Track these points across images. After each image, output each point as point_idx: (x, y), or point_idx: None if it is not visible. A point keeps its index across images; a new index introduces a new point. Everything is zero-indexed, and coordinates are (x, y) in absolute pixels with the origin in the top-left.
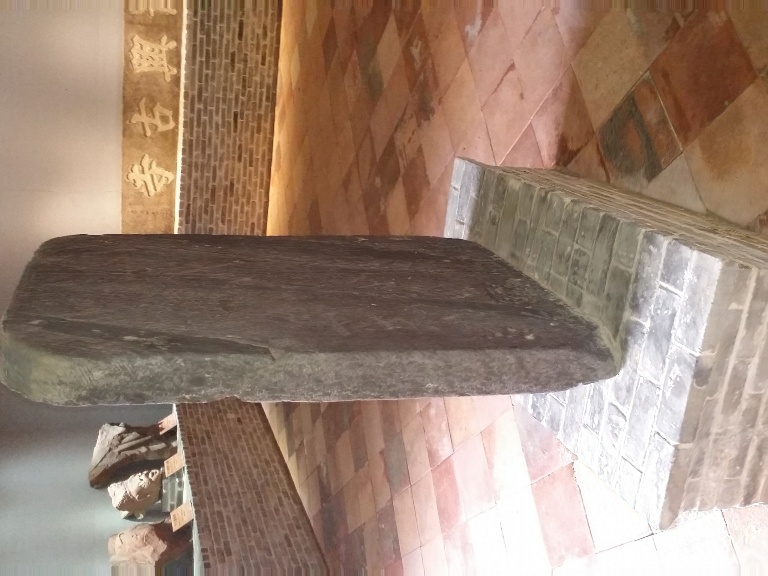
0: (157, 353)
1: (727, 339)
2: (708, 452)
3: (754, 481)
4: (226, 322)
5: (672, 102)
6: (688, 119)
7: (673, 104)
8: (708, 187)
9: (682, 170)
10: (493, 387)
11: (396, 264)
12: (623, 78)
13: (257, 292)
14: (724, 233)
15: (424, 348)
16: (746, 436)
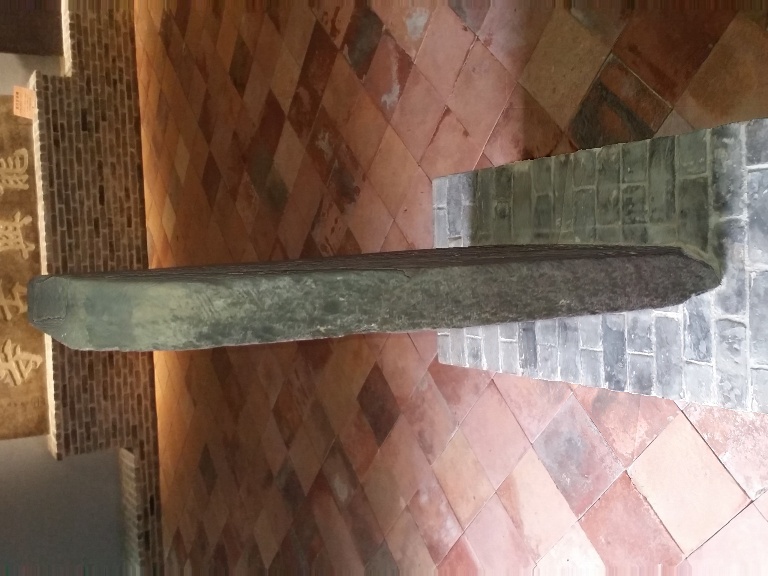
0: (282, 275)
1: None
2: None
3: None
4: None
5: (647, 69)
6: (670, 77)
7: (649, 71)
8: None
9: (677, 125)
10: (619, 302)
11: None
12: (584, 70)
13: (325, 261)
14: None
15: (550, 259)
16: None
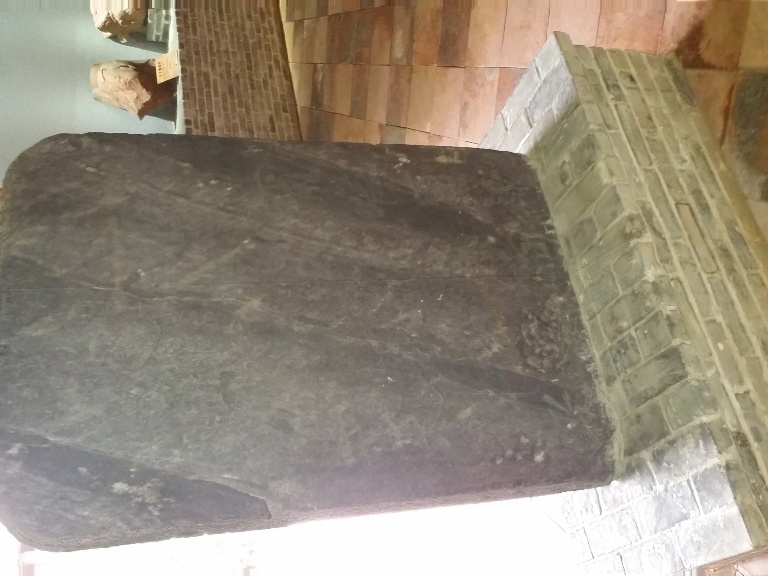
0: (148, 524)
1: None
2: None
3: None
4: (225, 437)
5: None
6: None
7: None
8: None
9: None
10: None
11: (432, 250)
12: None
13: (264, 346)
14: None
15: (426, 494)
16: None
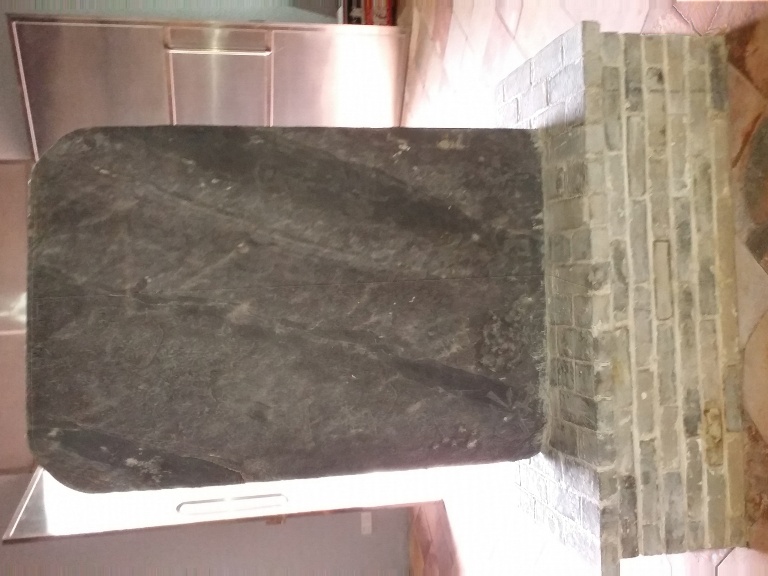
0: (152, 488)
1: None
2: None
3: None
4: (212, 425)
5: None
6: None
7: None
8: (760, 344)
9: (765, 296)
10: None
11: (413, 251)
12: None
13: (249, 348)
14: (704, 429)
15: (369, 472)
16: None
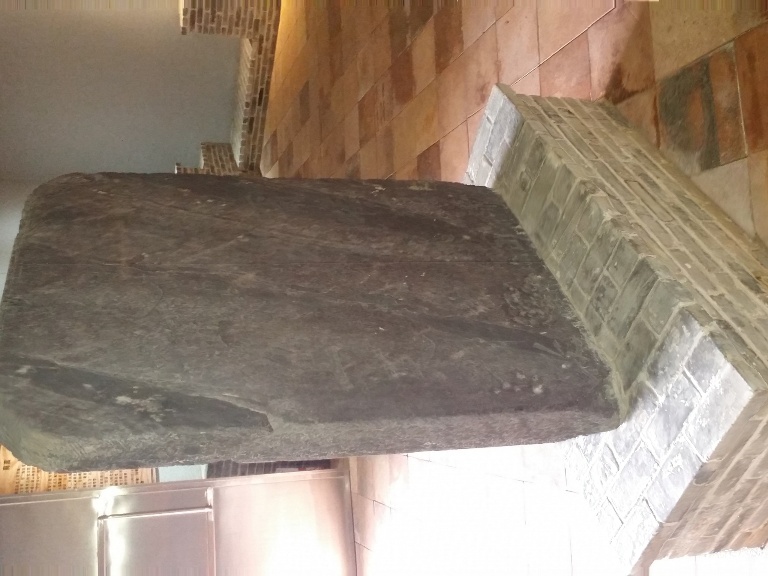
0: (151, 428)
1: (738, 444)
2: (691, 520)
3: (729, 537)
4: (224, 366)
5: (750, 94)
6: (763, 123)
7: (751, 97)
8: (764, 210)
9: (741, 177)
10: (492, 442)
11: (411, 244)
12: (702, 35)
13: (260, 304)
14: (767, 289)
15: (427, 414)
16: (732, 508)
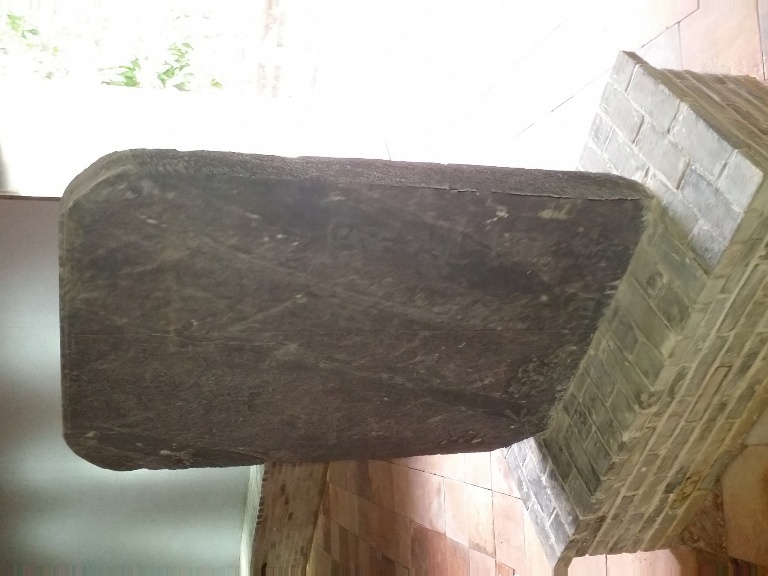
0: None
1: None
2: None
3: None
4: (244, 430)
5: None
6: None
7: None
8: (763, 459)
9: None
10: None
11: (477, 307)
12: None
13: (291, 377)
14: None
15: None
16: None
